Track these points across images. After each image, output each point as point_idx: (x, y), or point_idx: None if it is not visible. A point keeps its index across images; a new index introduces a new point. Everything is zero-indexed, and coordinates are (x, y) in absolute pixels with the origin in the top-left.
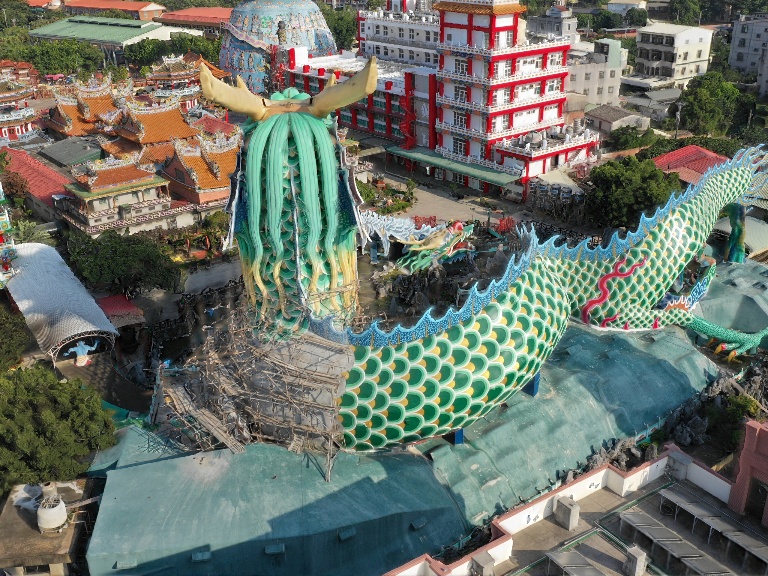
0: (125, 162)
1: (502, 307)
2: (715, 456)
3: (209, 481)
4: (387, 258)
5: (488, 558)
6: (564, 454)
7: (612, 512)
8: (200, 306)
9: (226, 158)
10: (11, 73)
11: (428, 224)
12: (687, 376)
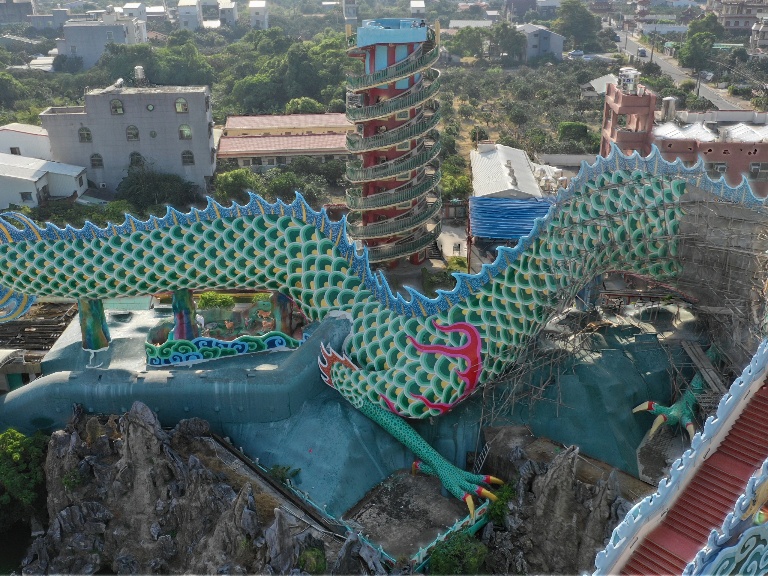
0: None
1: None
2: None
3: None
4: None
5: None
6: None
7: (710, 149)
8: None
9: None
10: None
11: None
12: None
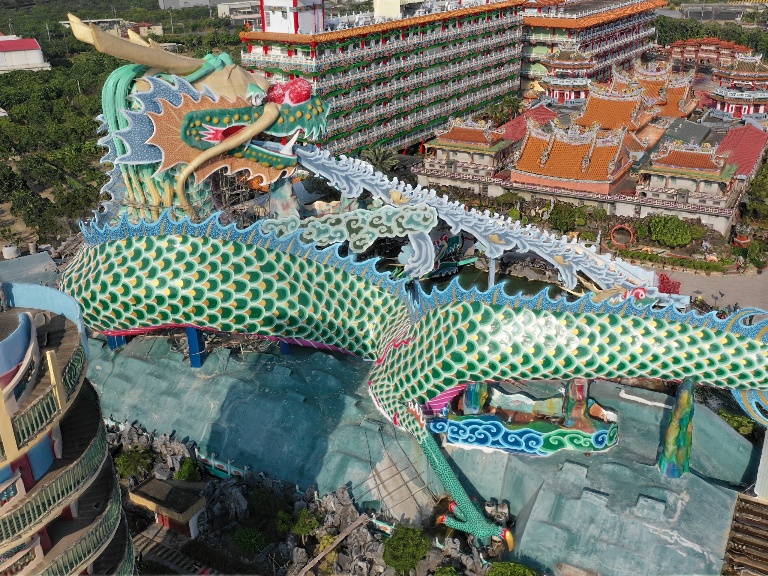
0: (480, 126)
1: (109, 248)
2: (180, 506)
3: (29, 273)
4: None
5: None
6: (152, 415)
7: None
8: (396, 251)
9: (571, 150)
10: (729, 55)
11: (671, 288)
12: (322, 468)
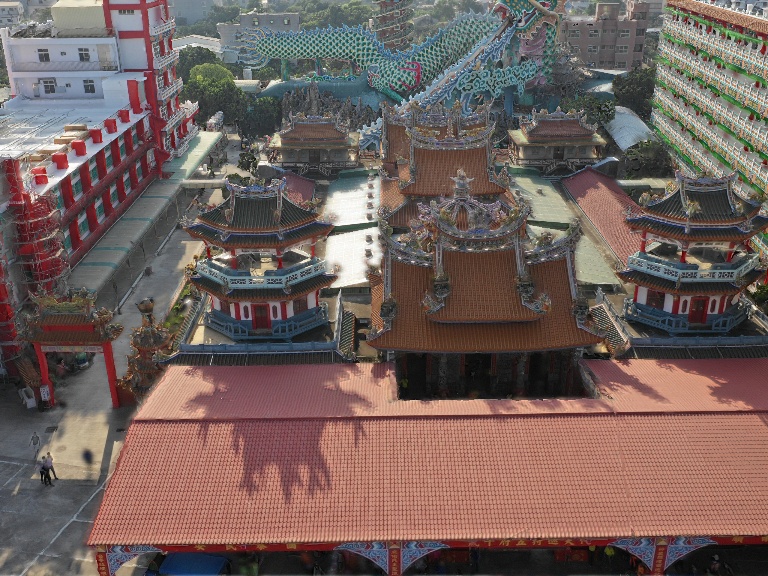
0: (546, 117)
1: None
2: None
3: None
4: None
5: None
6: None
7: None
8: None
9: None
10: None
11: None
12: None
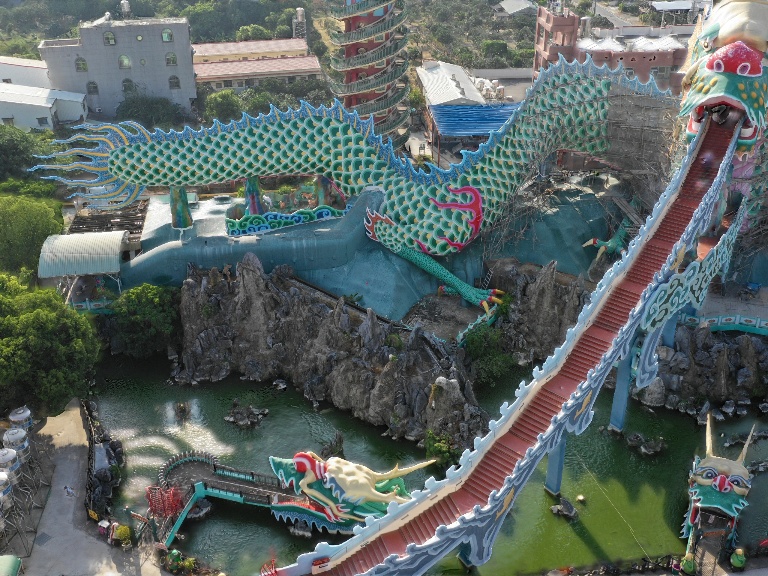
0: None
1: None
2: None
3: None
4: (432, 567)
5: (682, 47)
6: None
7: None
8: None
9: None
10: None
11: None
12: None
